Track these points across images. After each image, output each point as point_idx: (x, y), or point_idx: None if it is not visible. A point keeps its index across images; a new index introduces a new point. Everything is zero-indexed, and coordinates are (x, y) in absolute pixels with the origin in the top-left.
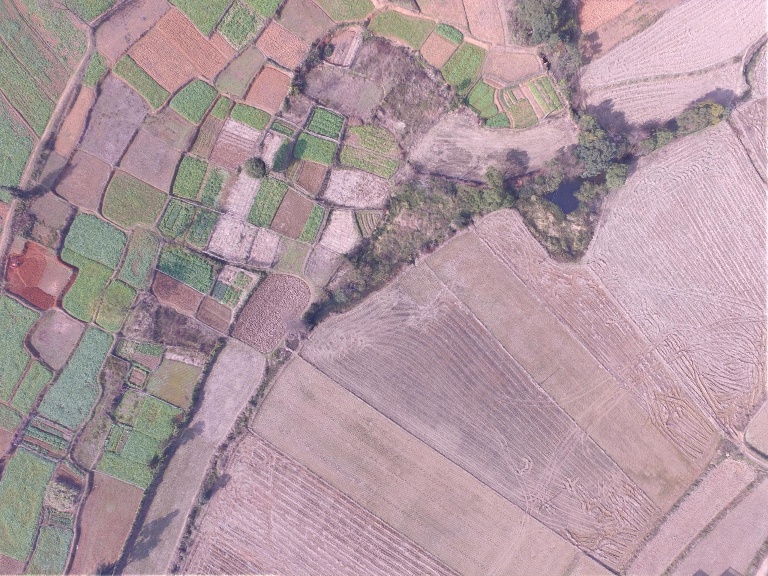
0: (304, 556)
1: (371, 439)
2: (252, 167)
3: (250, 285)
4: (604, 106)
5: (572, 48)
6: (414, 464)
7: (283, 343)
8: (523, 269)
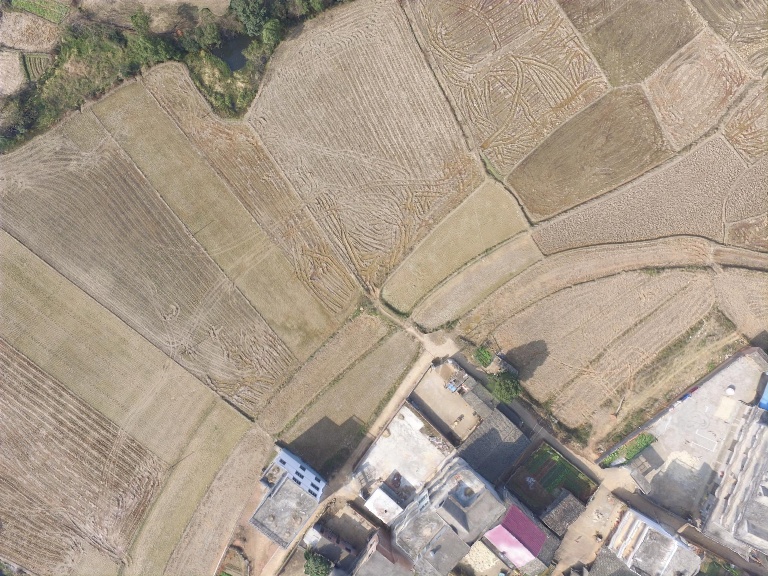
0: None
1: (24, 279)
2: None
3: None
4: None
5: None
6: (65, 306)
7: None
8: (186, 122)
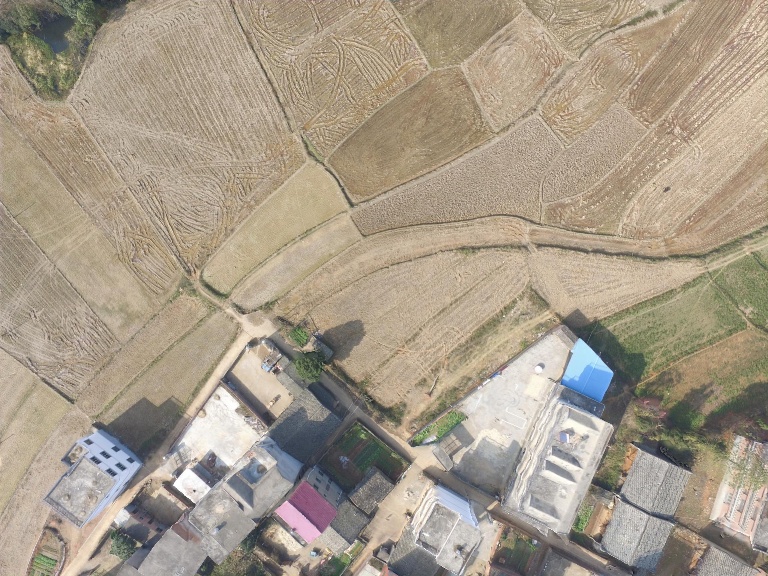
0: None
1: None
2: None
3: None
4: None
5: None
6: None
7: None
8: (8, 104)
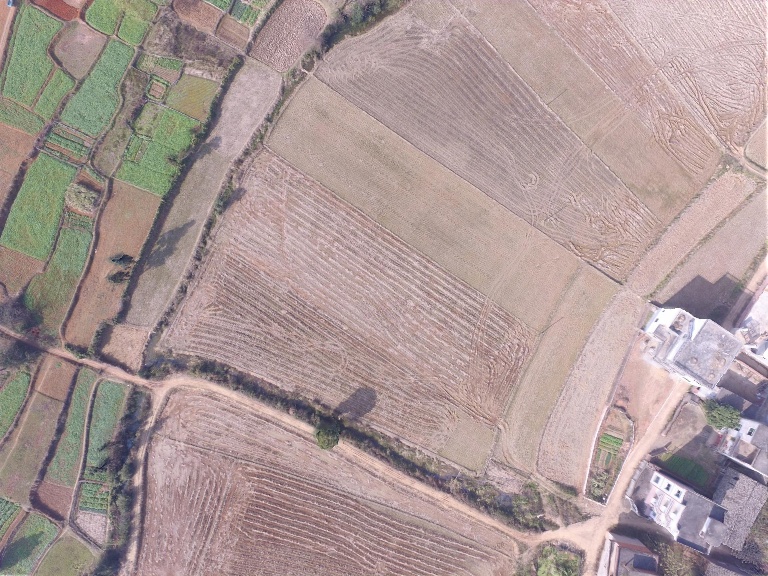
0: (316, 265)
1: (383, 156)
2: None
3: (268, 5)
4: None
5: None
6: (424, 180)
7: (299, 63)
8: None
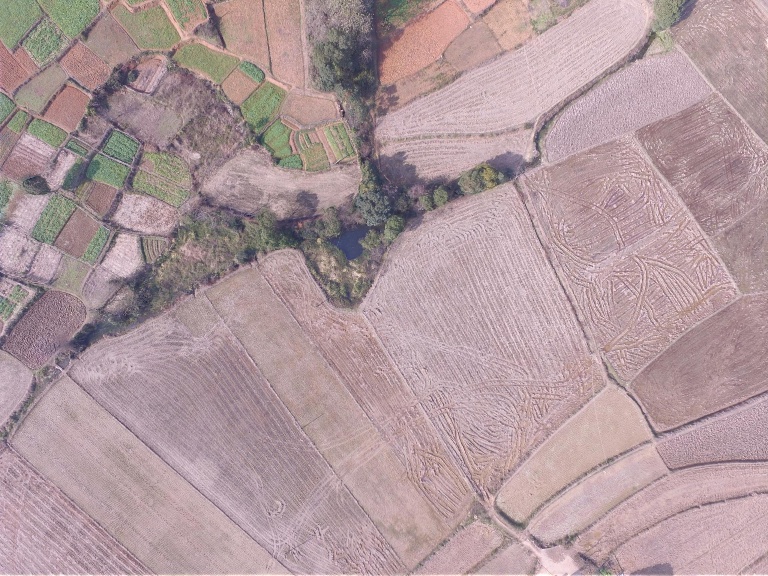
0: None
1: (128, 466)
2: (23, 184)
3: (25, 299)
4: (397, 158)
5: (352, 99)
6: (168, 496)
7: (53, 361)
8: (300, 310)
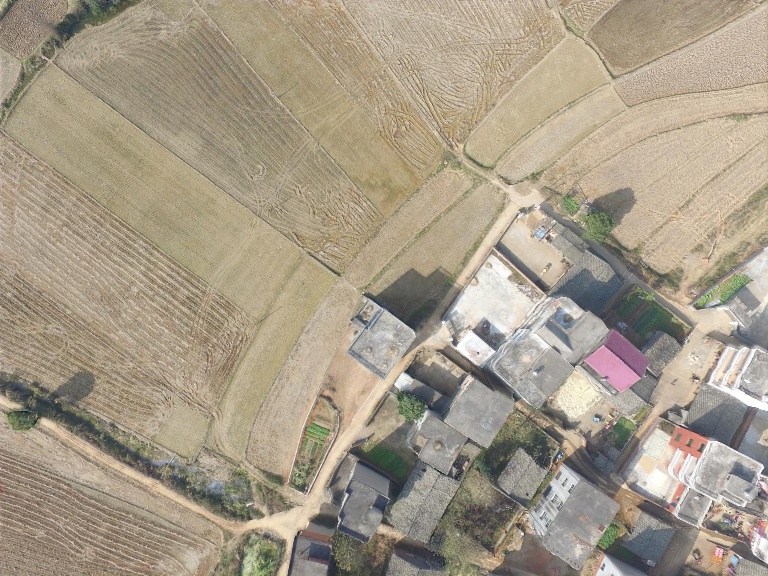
0: (43, 249)
1: (116, 143)
2: None
3: None
4: None
5: None
6: (155, 168)
7: (39, 51)
8: None
